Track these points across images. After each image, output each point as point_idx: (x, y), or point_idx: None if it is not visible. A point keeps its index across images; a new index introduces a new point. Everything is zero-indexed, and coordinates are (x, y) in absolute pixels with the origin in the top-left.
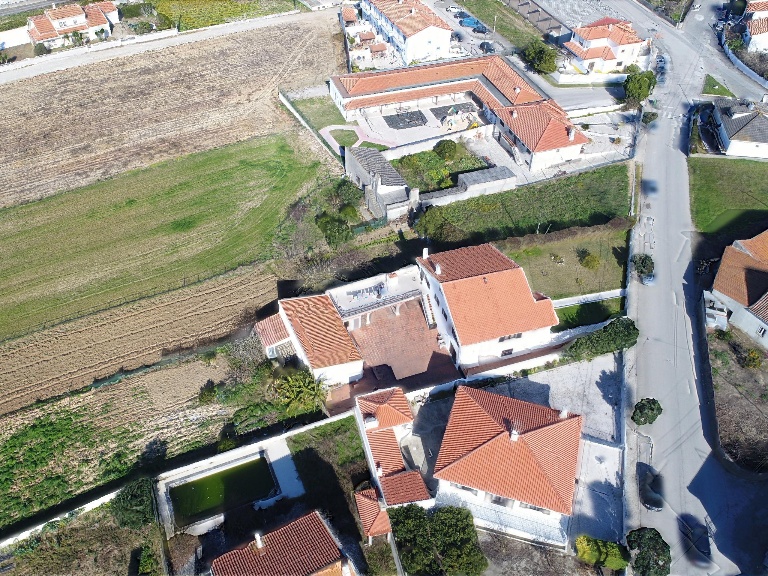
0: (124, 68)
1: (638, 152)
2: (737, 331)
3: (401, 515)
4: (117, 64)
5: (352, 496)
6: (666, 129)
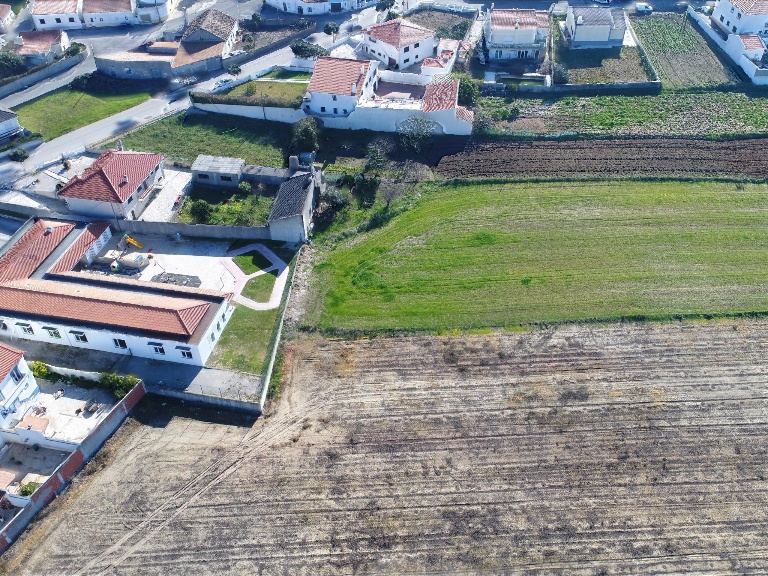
0: None
1: None
2: None
3: None
4: None
5: None
6: None
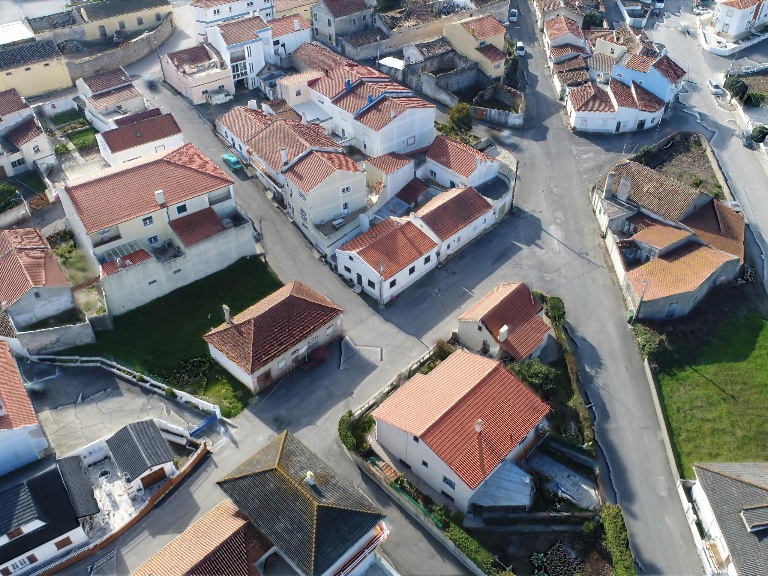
0: None
1: None
2: None
3: None
4: None
5: None
6: None
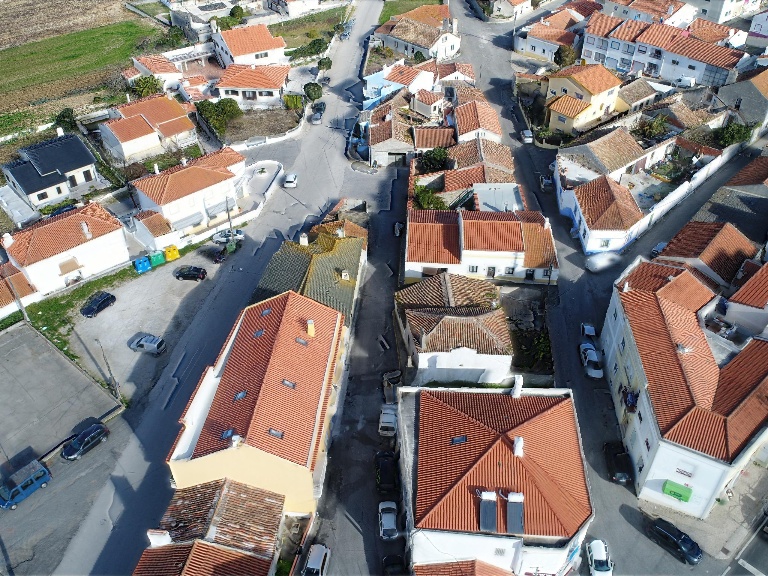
0: (11, 4)
1: (355, 2)
2: None
3: (201, 103)
4: (5, 3)
5: None
6: None
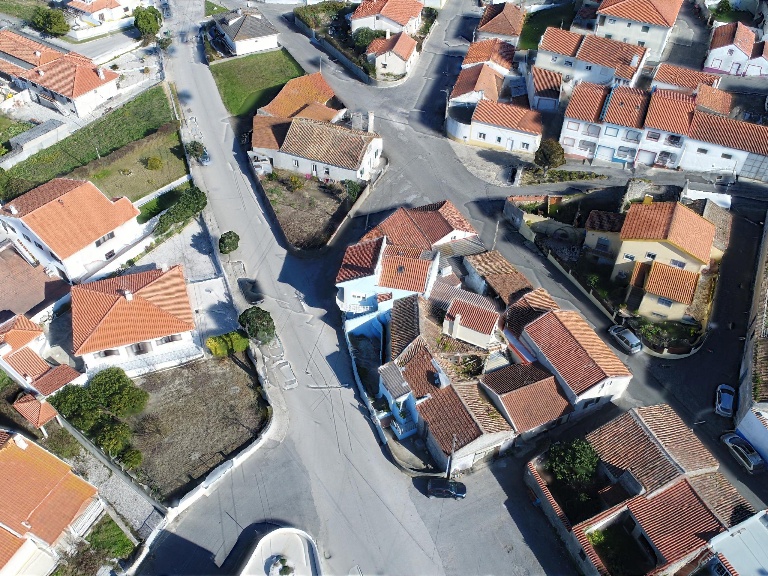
0: None
1: (167, 74)
2: (282, 171)
3: (61, 397)
4: None
5: (11, 409)
6: (185, 51)
